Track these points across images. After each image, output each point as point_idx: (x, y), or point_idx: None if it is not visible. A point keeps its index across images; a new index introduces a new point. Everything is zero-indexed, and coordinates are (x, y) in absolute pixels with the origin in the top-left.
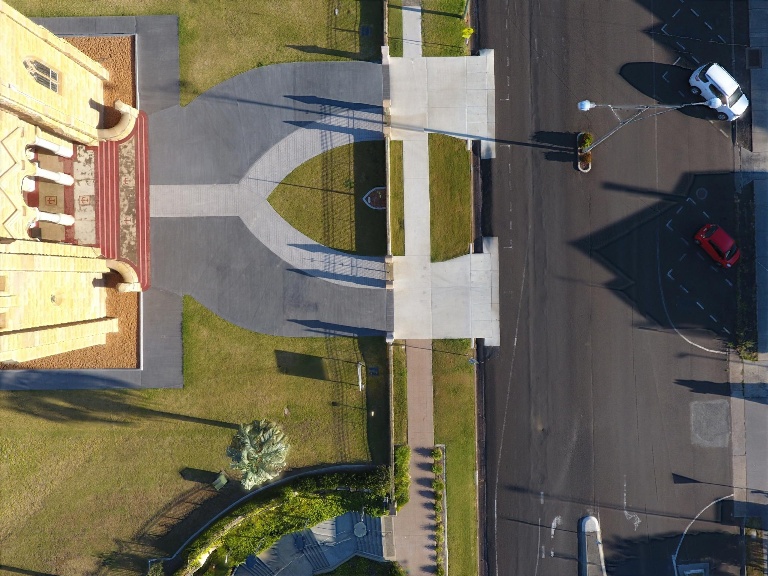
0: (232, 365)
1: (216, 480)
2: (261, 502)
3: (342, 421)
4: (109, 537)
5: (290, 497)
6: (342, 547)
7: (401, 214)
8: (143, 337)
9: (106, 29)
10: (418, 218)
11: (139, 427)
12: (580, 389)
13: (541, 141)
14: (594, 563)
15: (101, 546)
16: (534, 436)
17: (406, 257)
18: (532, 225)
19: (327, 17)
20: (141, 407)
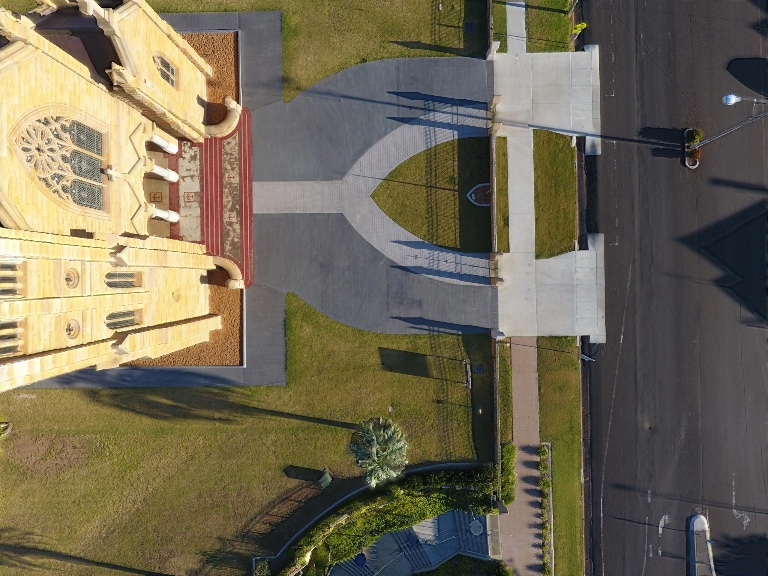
0: (336, 362)
1: (322, 478)
2: (367, 500)
3: (447, 419)
4: (212, 535)
5: (399, 495)
6: (444, 545)
7: (505, 211)
8: (246, 334)
9: (209, 25)
10: (523, 215)
11: (242, 425)
12: (688, 387)
13: (647, 137)
14: (703, 562)
15: (205, 544)
16: (641, 434)
17: (510, 254)
18: (638, 222)
19: (431, 13)
20: (244, 404)
